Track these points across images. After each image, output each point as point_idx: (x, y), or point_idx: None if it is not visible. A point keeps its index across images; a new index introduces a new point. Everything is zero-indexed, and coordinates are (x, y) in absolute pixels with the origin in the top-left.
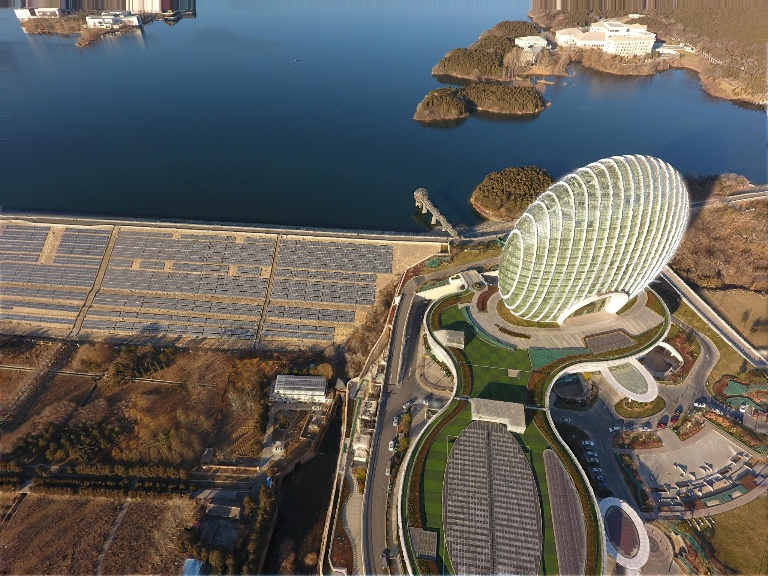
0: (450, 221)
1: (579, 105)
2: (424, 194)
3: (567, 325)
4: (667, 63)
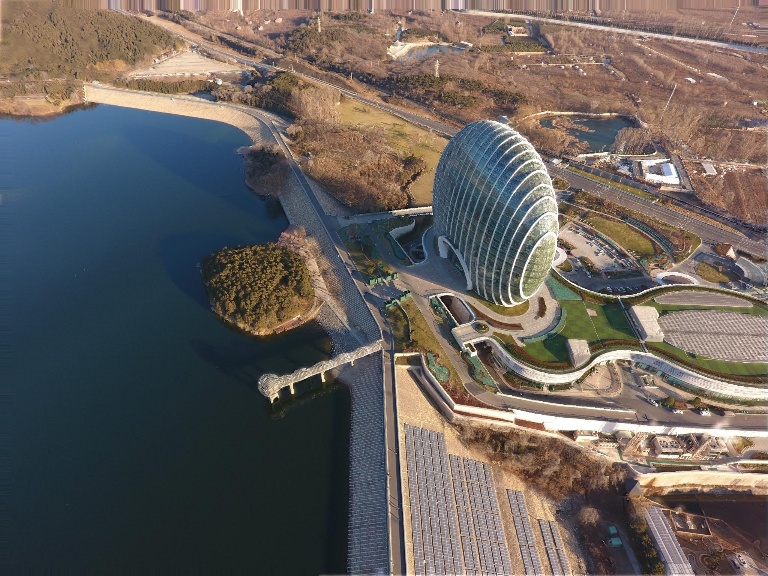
0: (315, 361)
1: None
2: (278, 377)
3: None
4: None
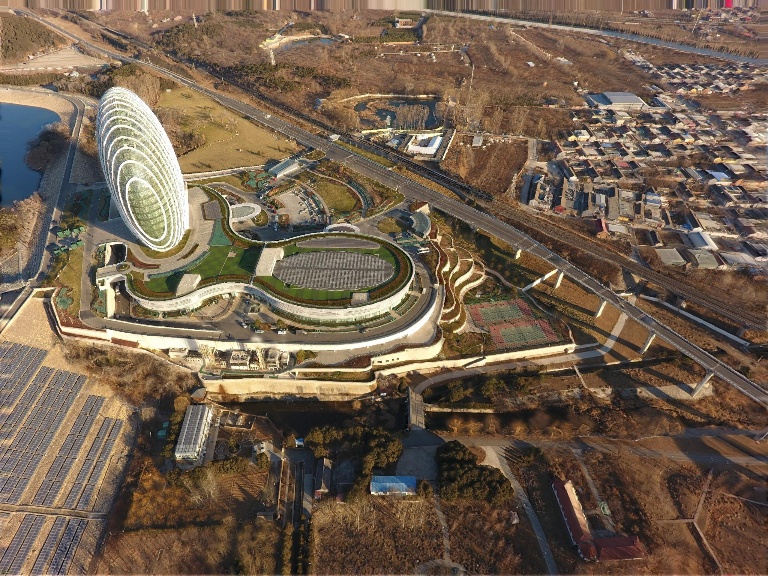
0: None
1: None
2: None
3: (190, 226)
4: None
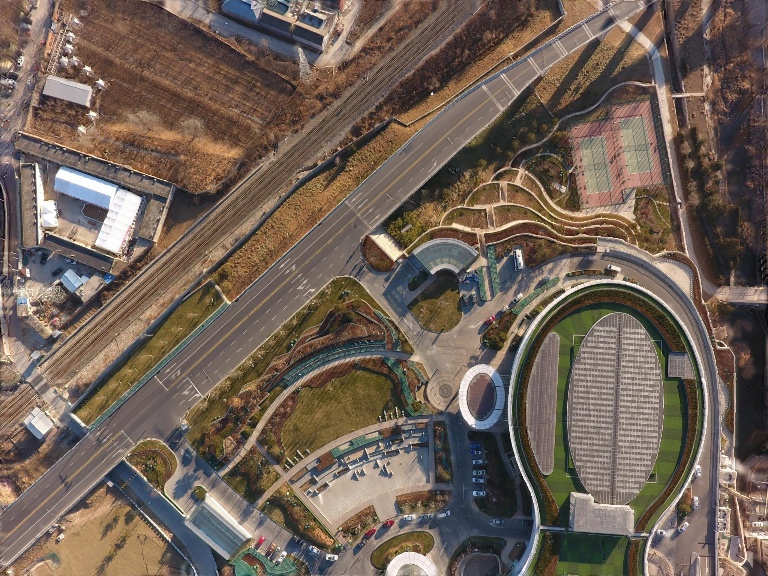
0: None
1: None
2: None
3: None
4: None
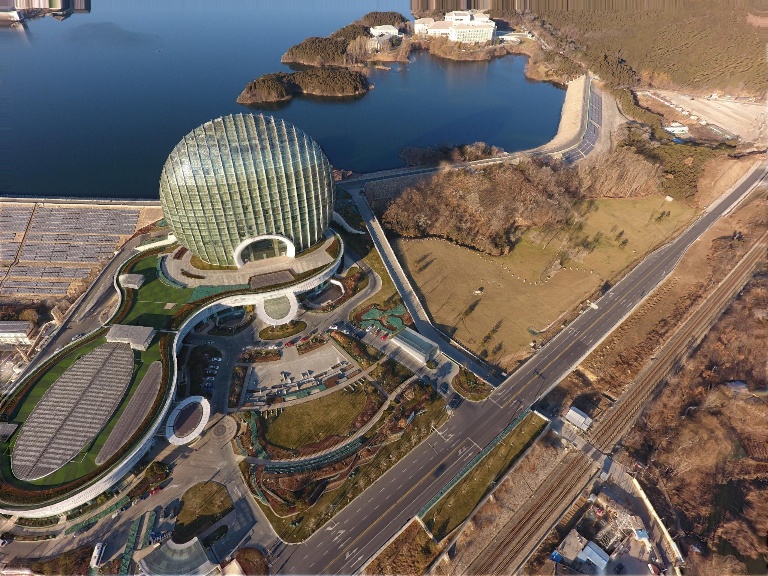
0: None
1: (401, 87)
2: None
3: (244, 267)
4: (504, 49)
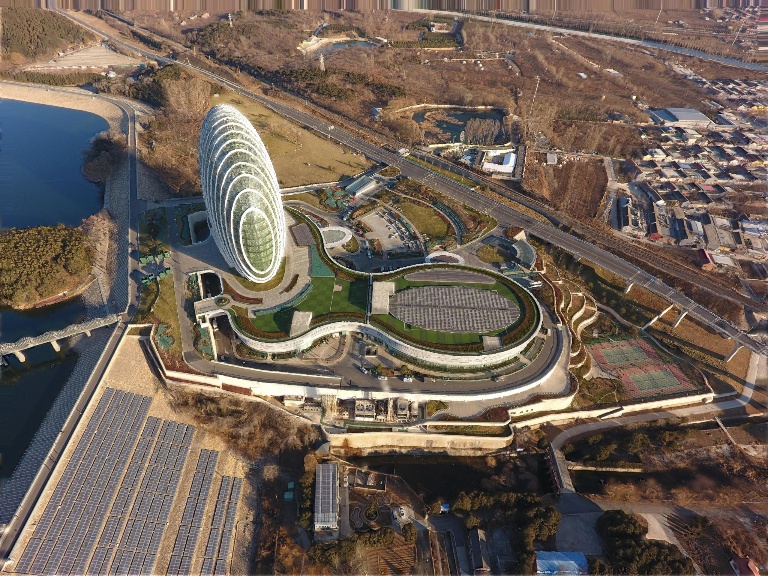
0: None
1: None
2: None
3: None
4: None
